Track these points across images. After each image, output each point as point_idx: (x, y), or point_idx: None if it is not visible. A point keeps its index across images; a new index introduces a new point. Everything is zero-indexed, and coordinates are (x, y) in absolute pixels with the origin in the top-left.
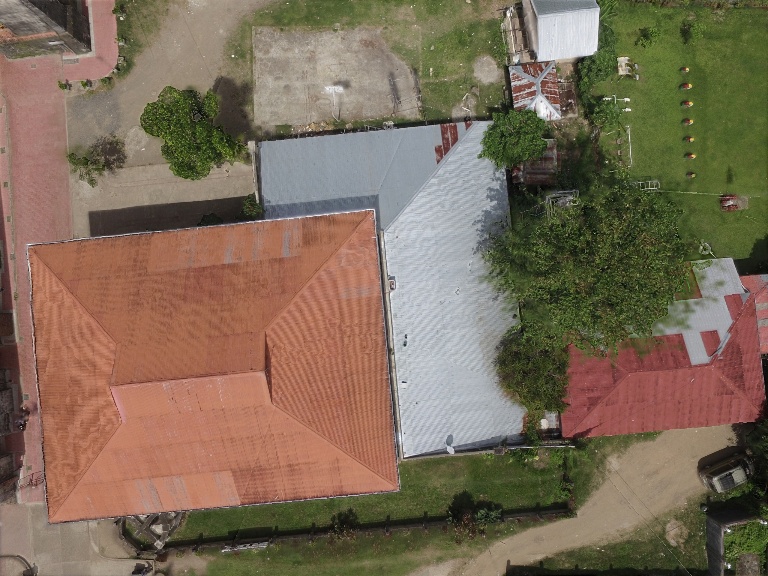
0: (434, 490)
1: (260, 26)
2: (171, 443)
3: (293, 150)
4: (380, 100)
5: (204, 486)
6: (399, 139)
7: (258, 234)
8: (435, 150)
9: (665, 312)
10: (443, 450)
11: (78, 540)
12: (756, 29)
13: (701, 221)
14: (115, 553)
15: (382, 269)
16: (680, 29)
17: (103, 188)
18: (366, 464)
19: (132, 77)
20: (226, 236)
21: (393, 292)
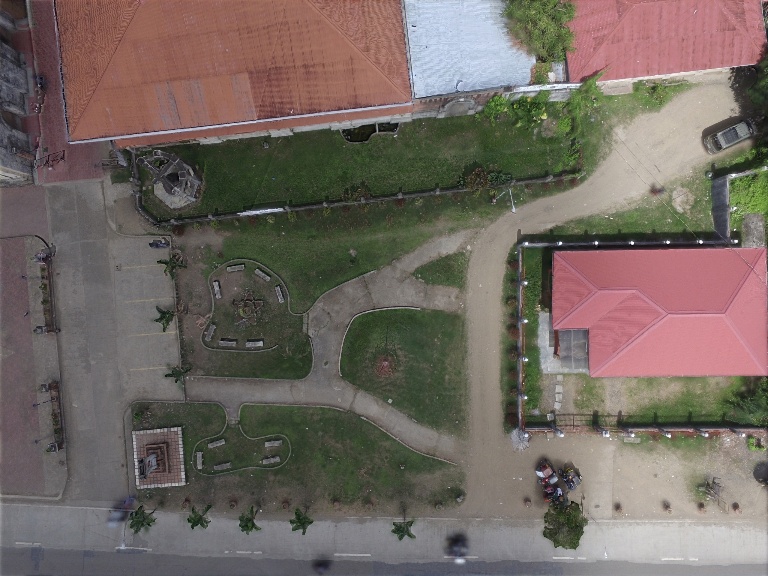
0: (445, 162)
1: None
2: (188, 34)
3: None
4: None
5: (221, 94)
6: None
7: None
8: None
9: None
10: (453, 93)
11: (95, 219)
12: None
13: None
14: (132, 230)
15: None
16: None
17: None
18: (379, 68)
19: None
20: None
21: None
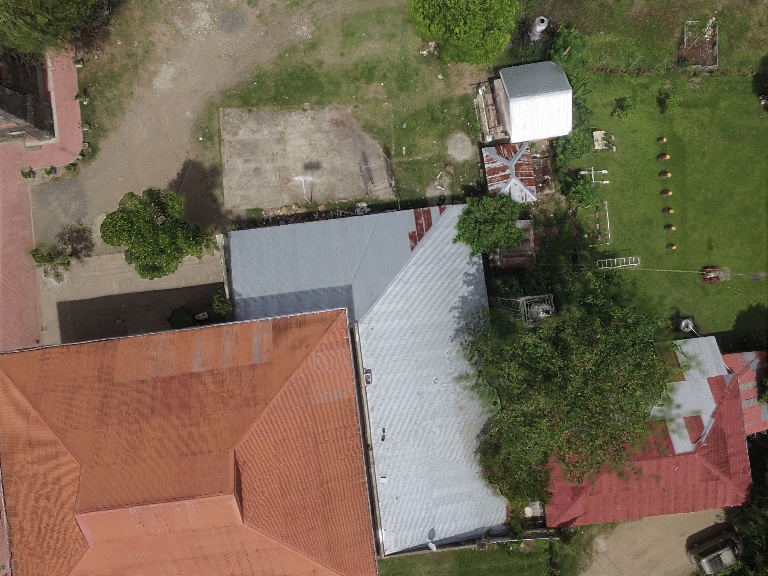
0: None
1: (228, 108)
2: (141, 563)
3: (263, 240)
4: (353, 181)
5: None
6: (372, 226)
7: (227, 338)
8: (409, 236)
9: (642, 435)
10: (425, 545)
11: None
12: (733, 96)
13: (683, 293)
14: None
15: (357, 363)
16: (656, 98)
17: (71, 278)
18: (344, 574)
19: (98, 163)
20: (194, 341)
21: (369, 386)
